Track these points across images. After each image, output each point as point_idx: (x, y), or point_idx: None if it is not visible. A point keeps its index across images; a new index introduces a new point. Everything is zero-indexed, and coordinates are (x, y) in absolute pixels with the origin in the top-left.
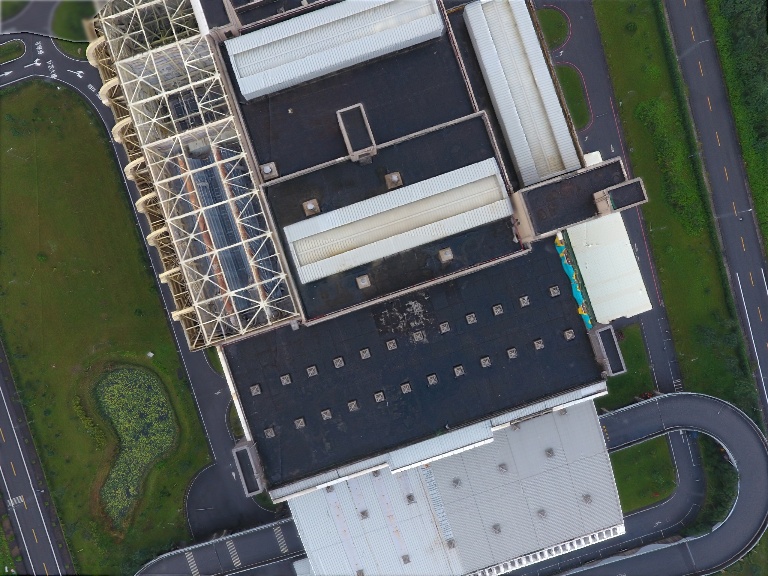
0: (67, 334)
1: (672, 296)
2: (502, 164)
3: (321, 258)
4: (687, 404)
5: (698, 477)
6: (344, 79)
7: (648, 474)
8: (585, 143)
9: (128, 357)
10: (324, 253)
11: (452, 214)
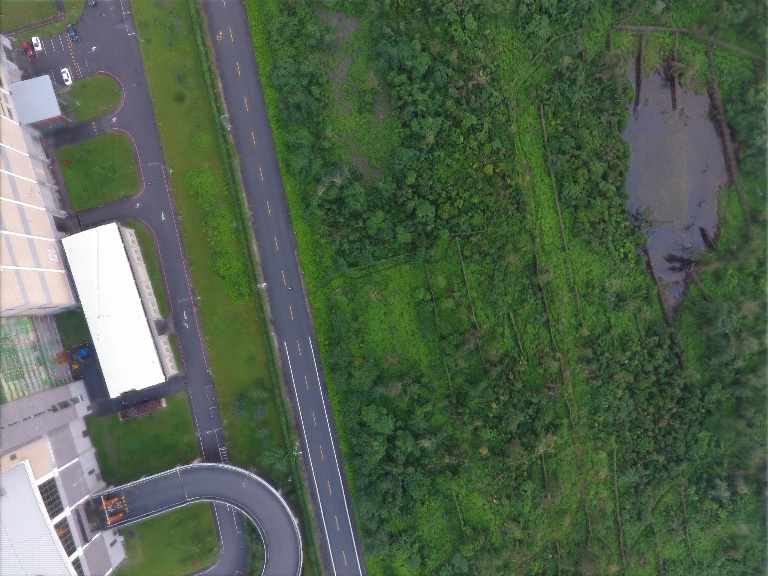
0: None
1: (218, 364)
2: None
3: None
4: (210, 475)
5: (242, 544)
6: None
7: (189, 542)
8: (136, 210)
9: None
10: None
11: None
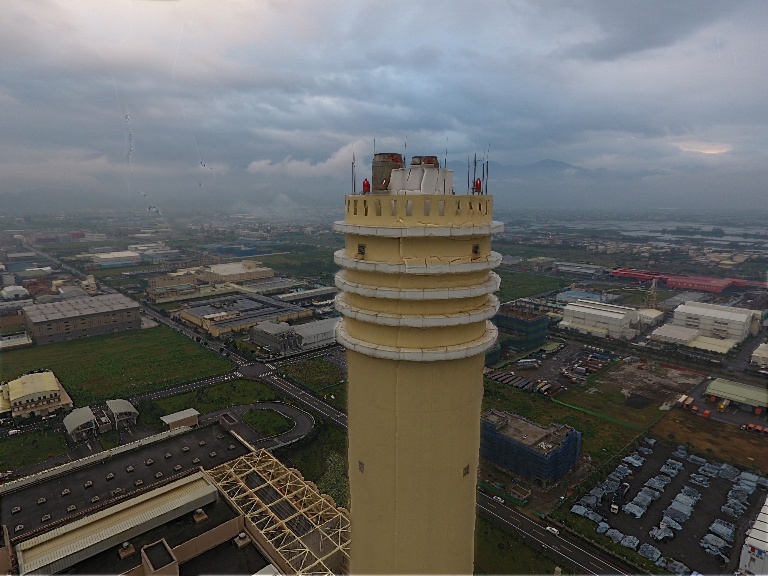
0: None
1: None
2: None
3: (188, 485)
4: None
5: None
6: None
7: None
8: None
9: None
10: None
11: (76, 532)
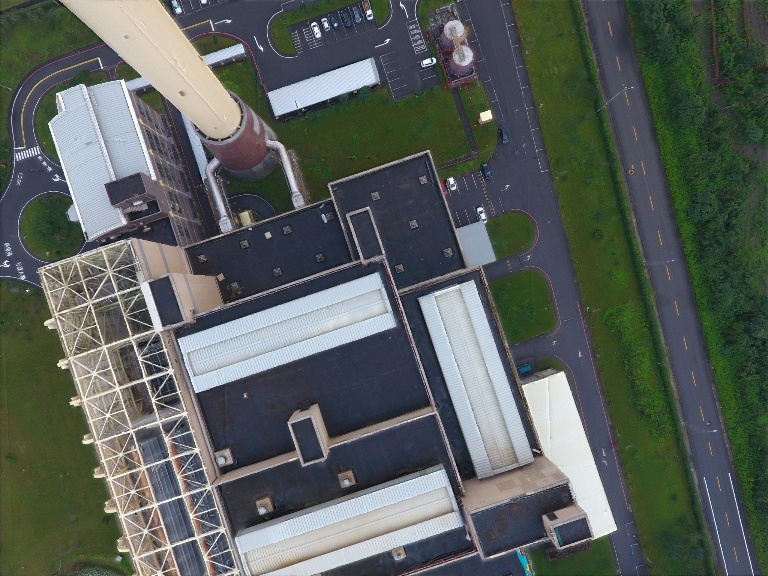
0: (36, 535)
1: (639, 501)
2: (454, 465)
3: (272, 567)
4: None
5: None
6: (299, 364)
7: None
8: (553, 347)
9: (97, 559)
10: (276, 562)
11: (403, 524)
